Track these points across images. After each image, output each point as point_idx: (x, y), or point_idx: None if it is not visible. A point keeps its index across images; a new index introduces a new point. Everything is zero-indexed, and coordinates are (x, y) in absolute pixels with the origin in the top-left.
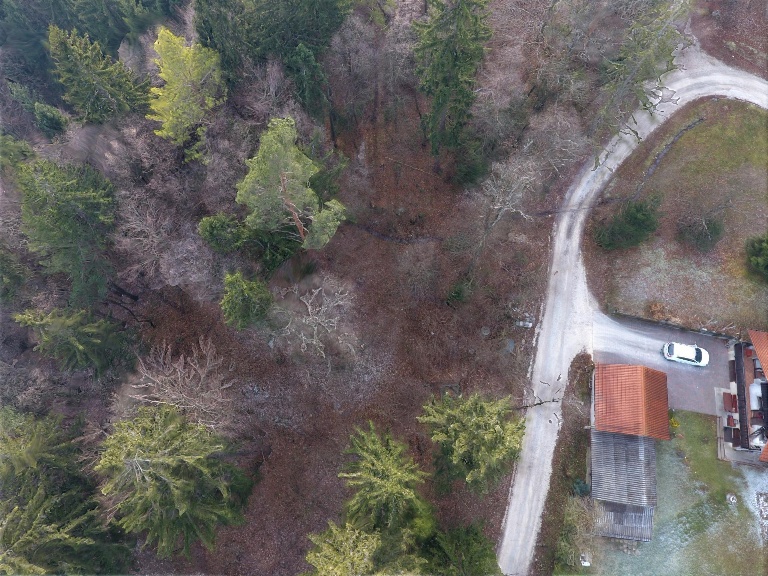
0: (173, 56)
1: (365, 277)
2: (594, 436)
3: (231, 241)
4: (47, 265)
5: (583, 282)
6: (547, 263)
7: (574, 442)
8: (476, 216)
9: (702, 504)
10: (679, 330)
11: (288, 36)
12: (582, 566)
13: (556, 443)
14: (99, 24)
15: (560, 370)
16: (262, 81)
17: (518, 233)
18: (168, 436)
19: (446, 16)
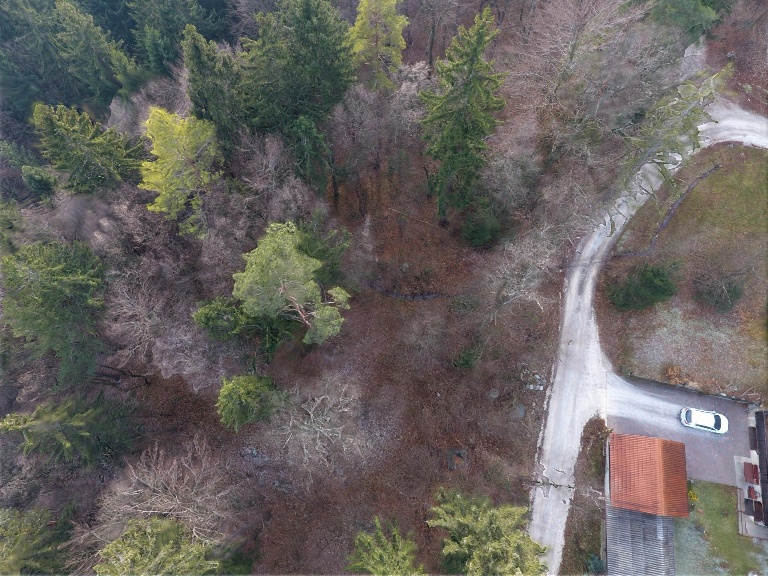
0: (165, 136)
1: (368, 337)
2: (609, 510)
3: (228, 327)
4: (33, 348)
5: (596, 341)
6: (558, 321)
7: (587, 513)
8: (484, 271)
9: None
10: (696, 393)
11: (288, 103)
12: None
13: (568, 513)
14: (90, 77)
15: (572, 435)
16: (261, 155)
17: (528, 290)
18: (159, 559)
19: (456, 91)
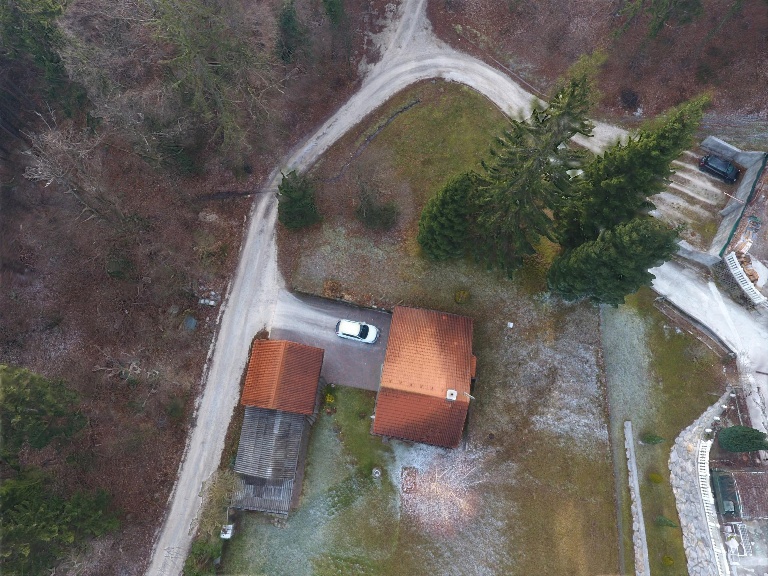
0: None
1: (57, 256)
2: (247, 411)
3: None
4: None
5: (274, 261)
6: (239, 242)
7: None
8: (175, 196)
9: (351, 478)
10: (358, 308)
11: None
12: (218, 538)
13: (231, 419)
14: None
15: (241, 347)
16: None
17: (210, 213)
18: None
19: None
